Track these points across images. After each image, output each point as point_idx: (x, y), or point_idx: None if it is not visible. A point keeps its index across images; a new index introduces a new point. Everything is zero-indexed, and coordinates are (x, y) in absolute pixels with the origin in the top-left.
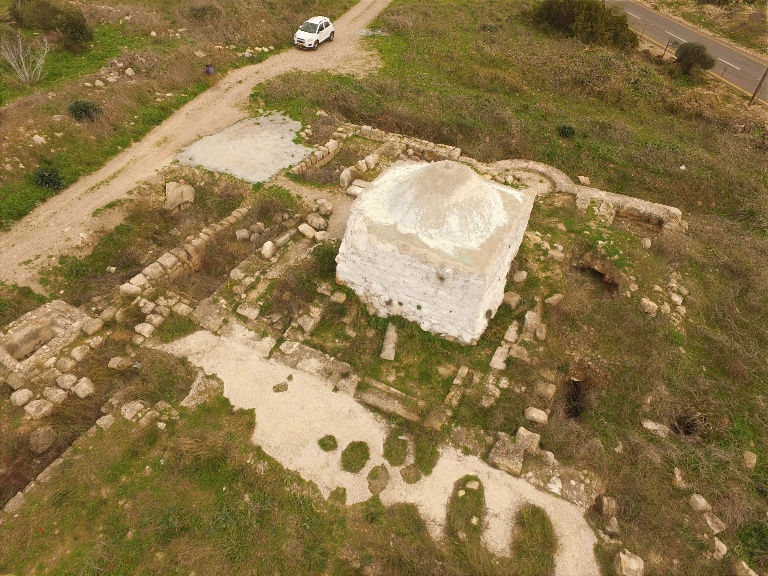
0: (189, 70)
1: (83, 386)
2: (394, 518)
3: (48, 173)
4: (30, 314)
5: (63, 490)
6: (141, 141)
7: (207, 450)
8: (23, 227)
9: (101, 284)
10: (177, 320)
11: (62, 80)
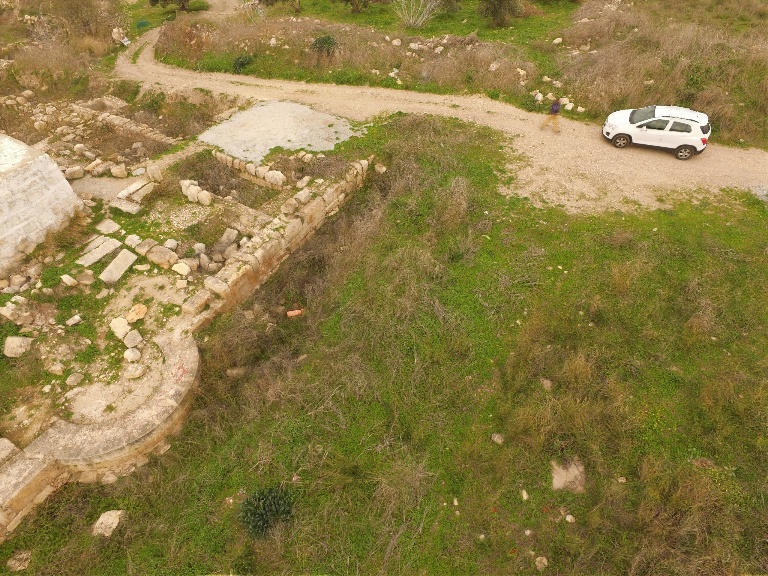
0: None
1: (37, 123)
2: None
3: (243, 60)
4: (116, 99)
5: None
6: (307, 84)
7: None
8: (201, 75)
9: (142, 116)
10: None
11: None
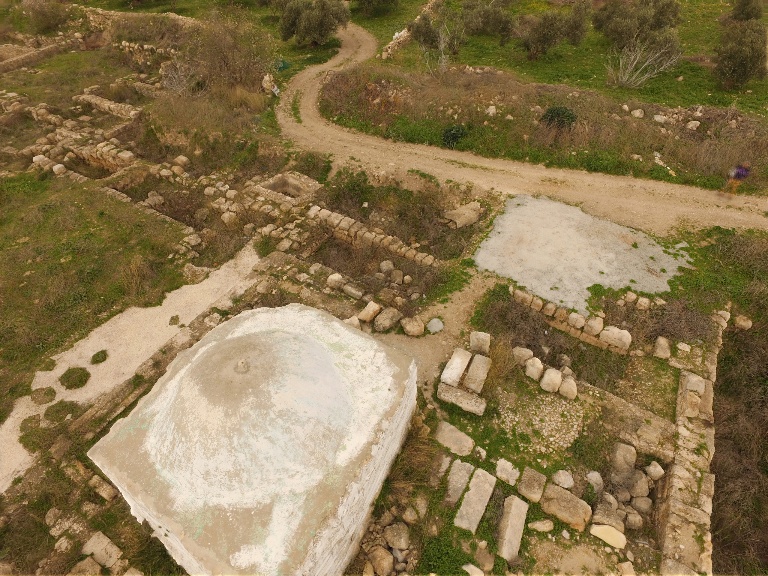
0: (737, 160)
1: (226, 215)
2: (2, 406)
3: (456, 132)
4: (306, 177)
5: (142, 224)
6: (548, 168)
7: (127, 278)
8: (399, 146)
9: (343, 203)
10: (271, 244)
11: (645, 98)
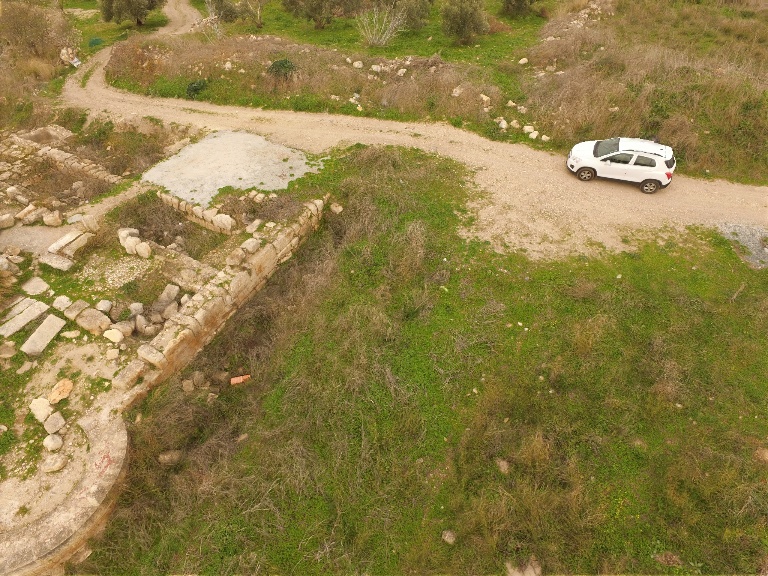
0: None
1: None
2: None
3: (197, 85)
4: (61, 128)
5: None
6: (264, 110)
7: None
8: None
9: (88, 147)
10: None
11: (385, 54)
